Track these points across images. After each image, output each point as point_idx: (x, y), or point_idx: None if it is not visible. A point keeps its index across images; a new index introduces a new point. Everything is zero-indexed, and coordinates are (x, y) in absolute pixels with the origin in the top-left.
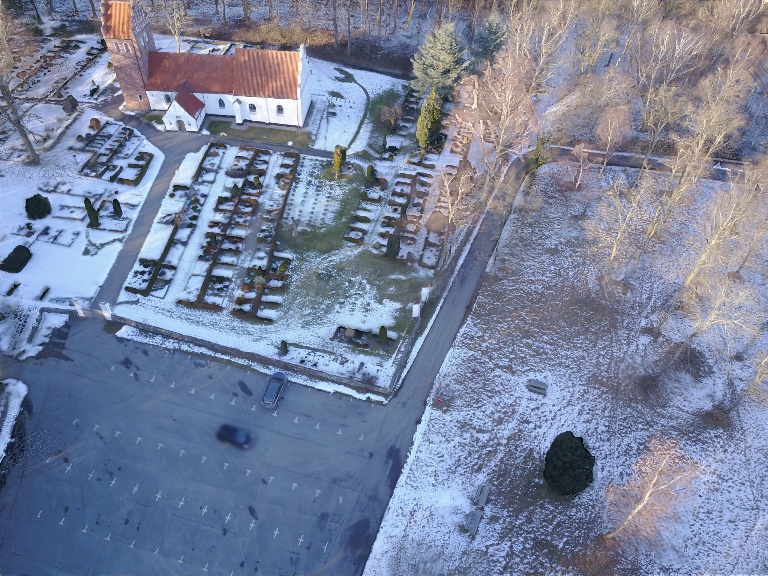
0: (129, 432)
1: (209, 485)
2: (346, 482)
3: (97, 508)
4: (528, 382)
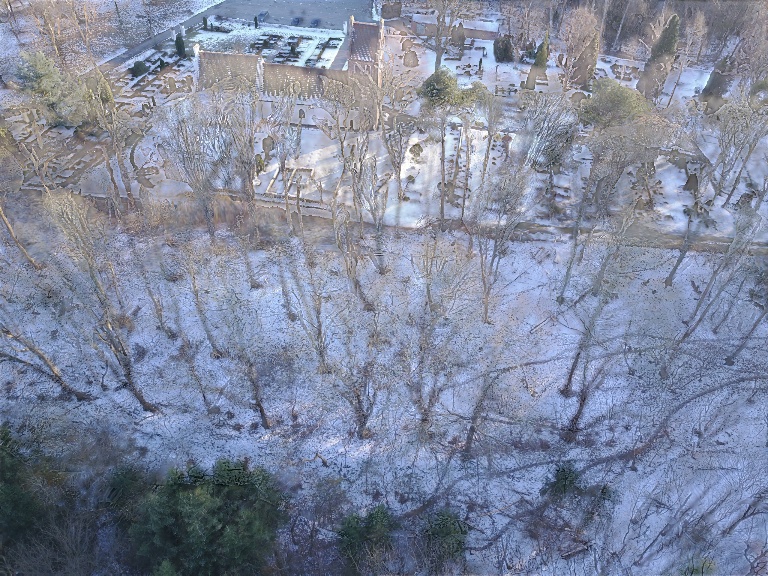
0: (325, 13)
1: (291, 5)
2: (239, 4)
3: (331, 3)
4: (144, 18)
